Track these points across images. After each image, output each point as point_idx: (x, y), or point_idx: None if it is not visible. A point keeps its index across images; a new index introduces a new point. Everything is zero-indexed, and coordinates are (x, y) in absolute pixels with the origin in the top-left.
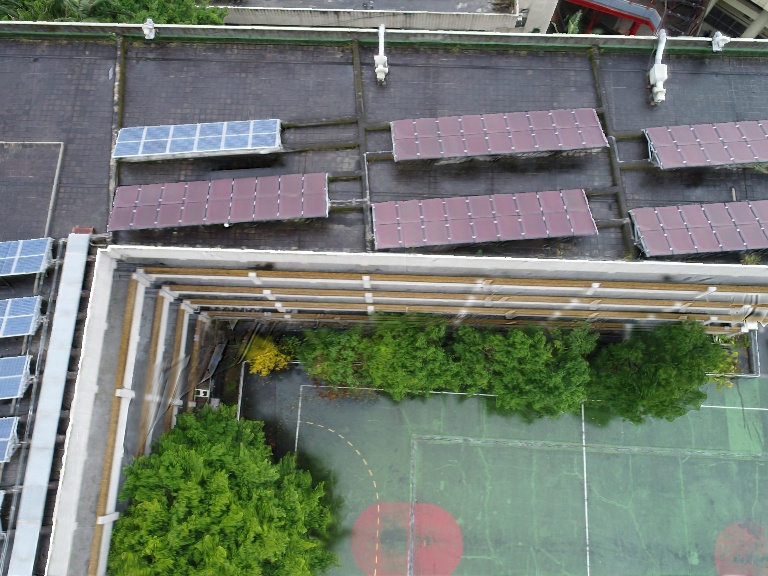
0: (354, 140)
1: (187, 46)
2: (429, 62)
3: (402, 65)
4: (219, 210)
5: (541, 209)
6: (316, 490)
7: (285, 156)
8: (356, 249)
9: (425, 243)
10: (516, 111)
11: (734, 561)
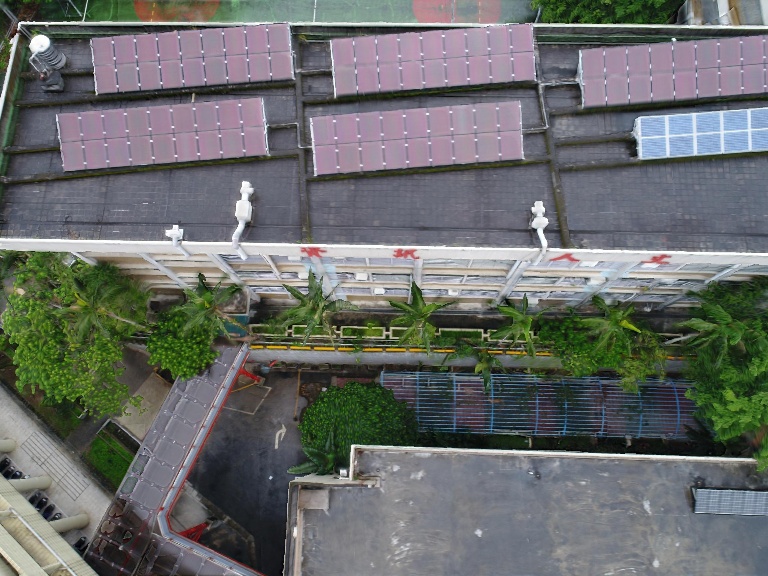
0: (560, 141)
1: (759, 252)
2: (485, 234)
3: (515, 231)
4: (684, 57)
5: (379, 69)
6: (539, 3)
7: (626, 131)
8: (546, 48)
9: (488, 29)
10: (394, 180)
11: (205, 2)
